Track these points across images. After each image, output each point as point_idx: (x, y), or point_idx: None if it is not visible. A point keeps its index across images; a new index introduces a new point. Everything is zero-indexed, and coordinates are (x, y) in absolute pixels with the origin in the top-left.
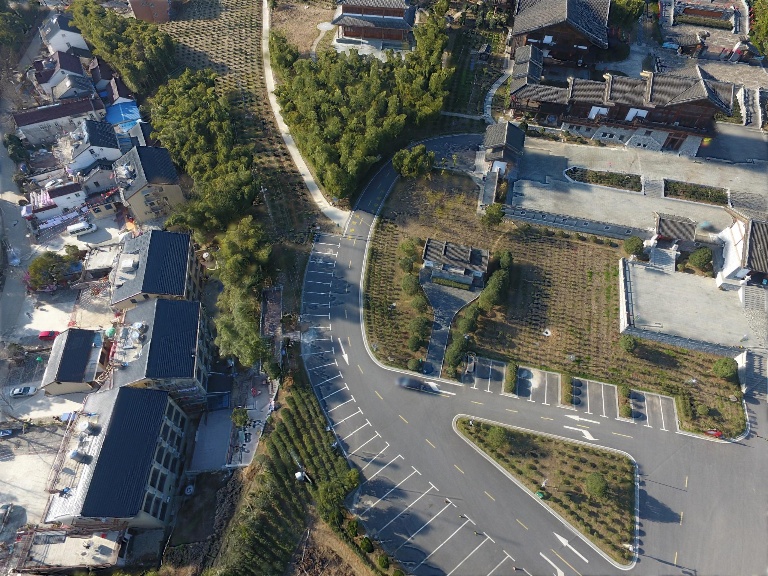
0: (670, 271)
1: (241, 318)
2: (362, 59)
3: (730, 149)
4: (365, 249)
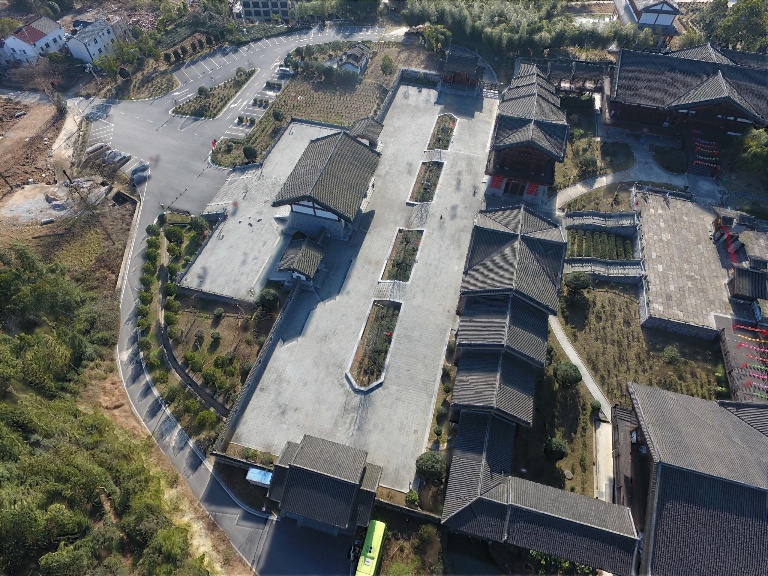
0: None
1: (320, 3)
2: (555, 8)
3: None
4: (372, 41)
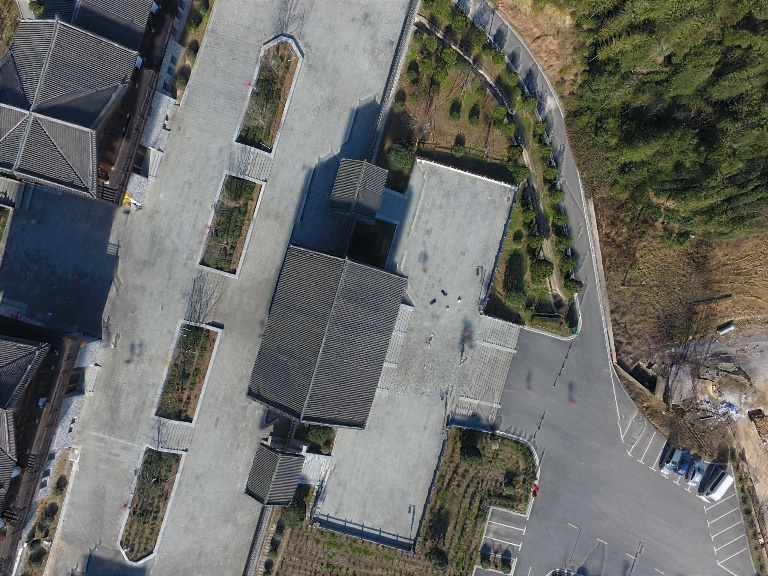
0: (330, 463)
1: None
2: None
3: (81, 269)
4: None
